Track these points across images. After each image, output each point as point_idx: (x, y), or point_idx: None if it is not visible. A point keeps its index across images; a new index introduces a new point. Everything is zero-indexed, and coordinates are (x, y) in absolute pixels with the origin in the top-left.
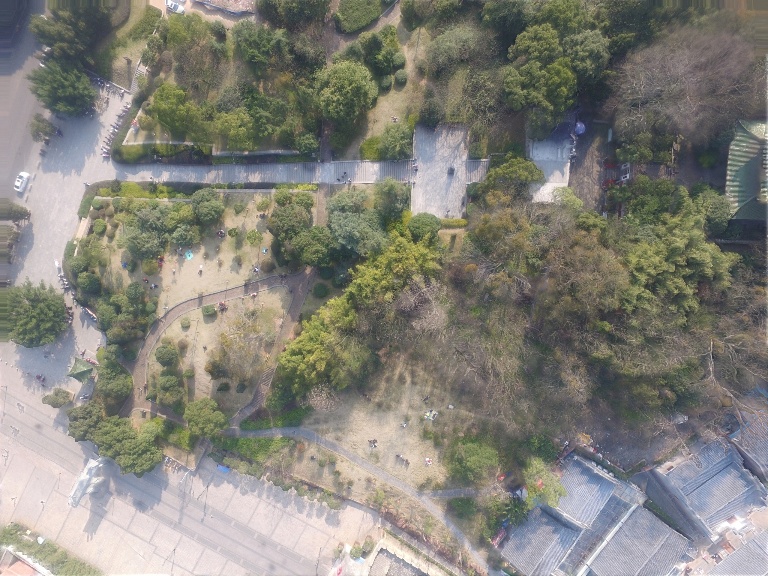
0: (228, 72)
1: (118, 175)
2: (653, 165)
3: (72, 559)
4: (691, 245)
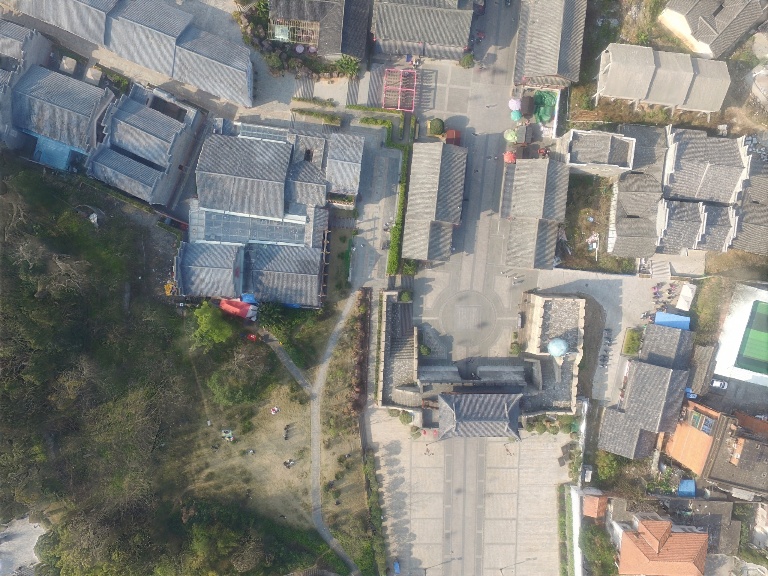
0: None
1: None
2: None
3: None
4: None
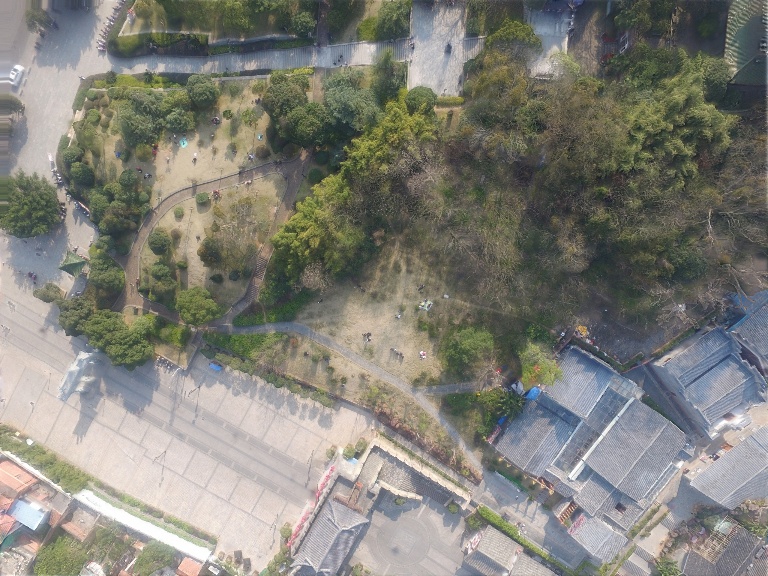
0: None
1: (113, 69)
2: (652, 39)
3: (61, 461)
4: (689, 105)
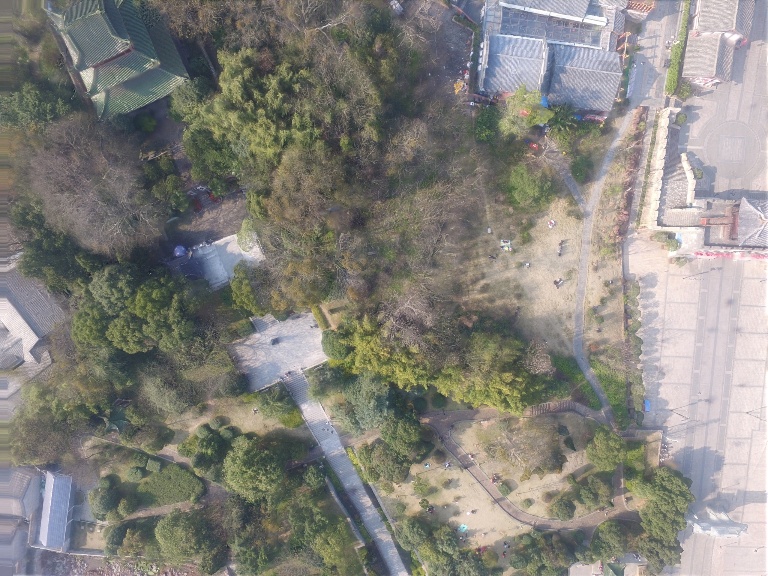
0: (287, 567)
1: None
2: (178, 167)
3: None
4: (231, 105)
